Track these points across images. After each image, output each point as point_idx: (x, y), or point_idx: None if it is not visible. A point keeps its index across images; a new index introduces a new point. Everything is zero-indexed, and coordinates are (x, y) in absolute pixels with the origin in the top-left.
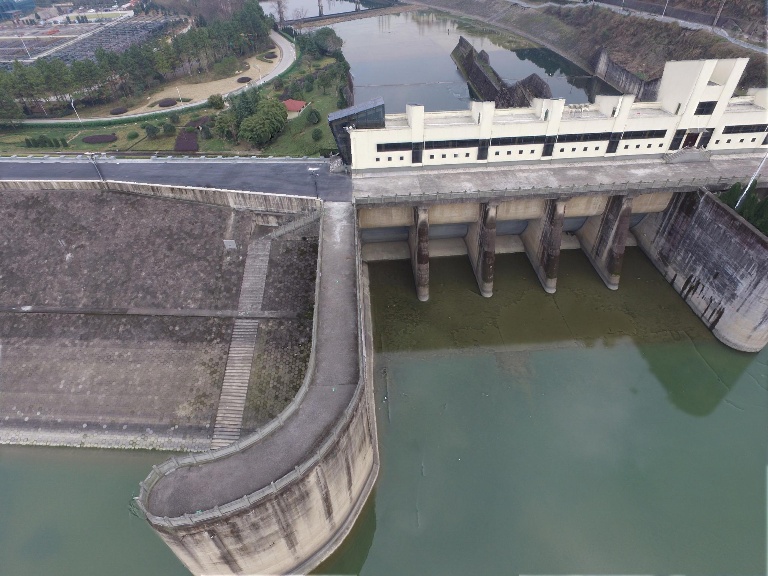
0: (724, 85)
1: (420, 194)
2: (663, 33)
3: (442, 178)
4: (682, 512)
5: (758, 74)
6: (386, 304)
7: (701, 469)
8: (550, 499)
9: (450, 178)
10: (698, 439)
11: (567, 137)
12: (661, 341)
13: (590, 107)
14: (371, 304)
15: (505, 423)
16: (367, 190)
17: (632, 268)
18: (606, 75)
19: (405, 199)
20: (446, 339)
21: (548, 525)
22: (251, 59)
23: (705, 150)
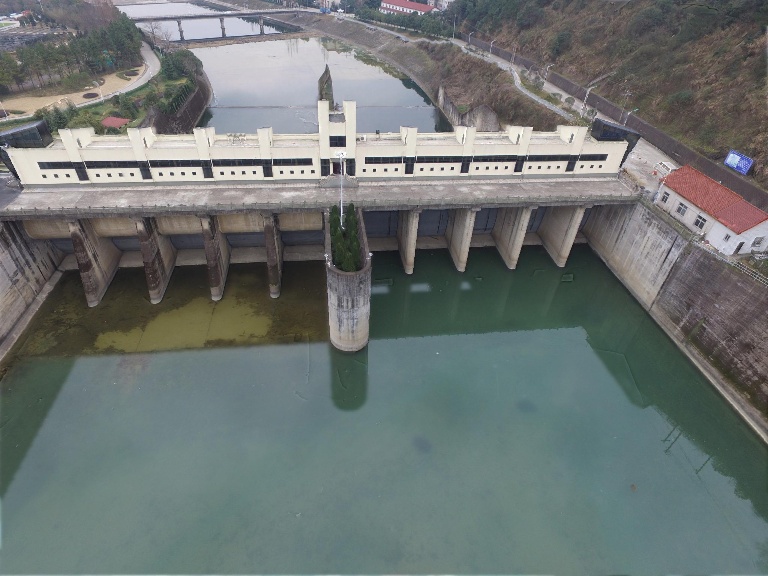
0: (345, 122)
1: (59, 208)
2: (488, 72)
3: (106, 195)
4: (191, 486)
5: (519, 113)
6: (54, 309)
7: (235, 450)
8: (80, 478)
9: (113, 195)
10: (252, 425)
11: (222, 162)
12: (281, 342)
13: (254, 136)
14: (39, 309)
15: (88, 414)
16: (24, 204)
17: (306, 279)
18: (444, 107)
19: (46, 212)
20: (87, 341)
21: (61, 500)
22: (110, 76)
23: (350, 177)
